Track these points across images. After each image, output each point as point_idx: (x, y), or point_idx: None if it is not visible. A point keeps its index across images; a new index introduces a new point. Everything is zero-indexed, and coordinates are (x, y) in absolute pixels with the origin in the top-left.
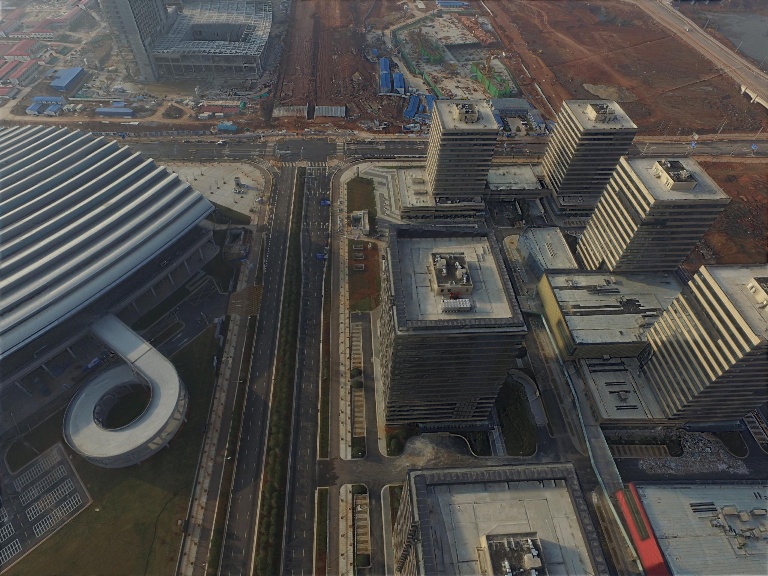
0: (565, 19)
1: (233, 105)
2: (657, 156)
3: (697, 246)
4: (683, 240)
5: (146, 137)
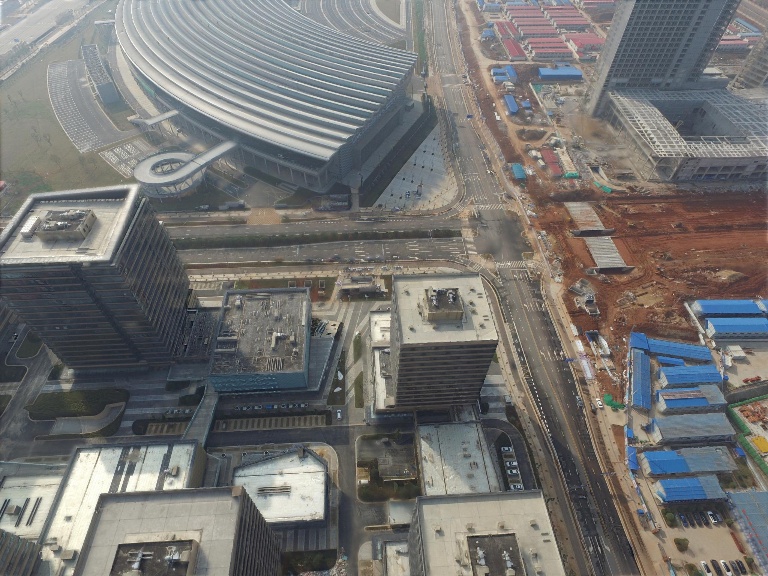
0: None
1: (567, 169)
2: (231, 570)
3: None
4: None
5: (484, 130)
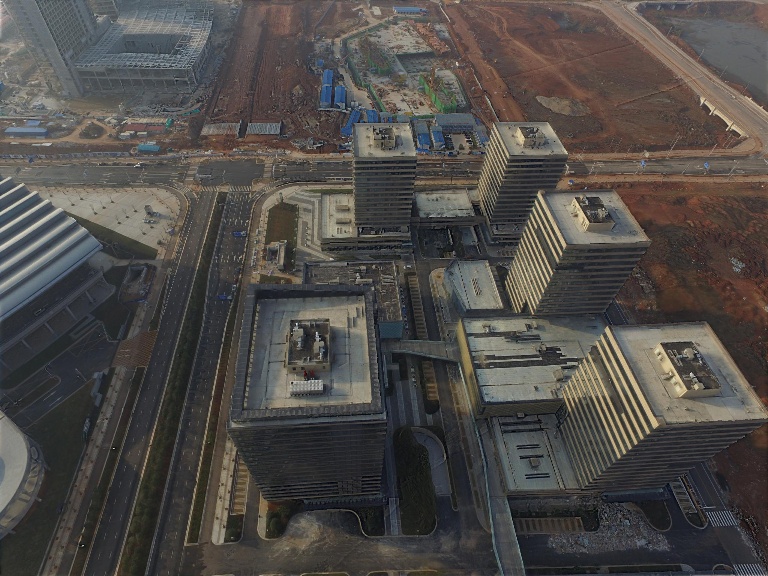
0: (525, 26)
1: (159, 123)
2: (578, 190)
3: (637, 278)
4: (606, 283)
5: (58, 159)
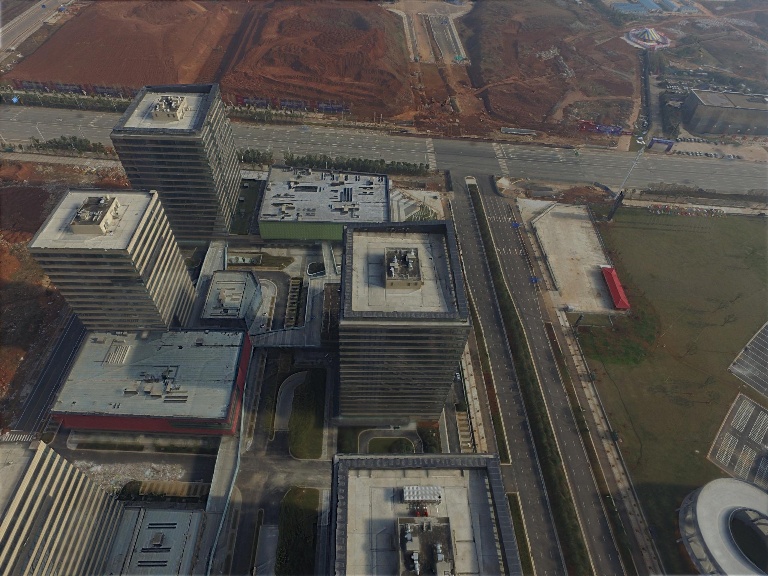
0: None
1: None
2: None
3: None
4: None
5: None
